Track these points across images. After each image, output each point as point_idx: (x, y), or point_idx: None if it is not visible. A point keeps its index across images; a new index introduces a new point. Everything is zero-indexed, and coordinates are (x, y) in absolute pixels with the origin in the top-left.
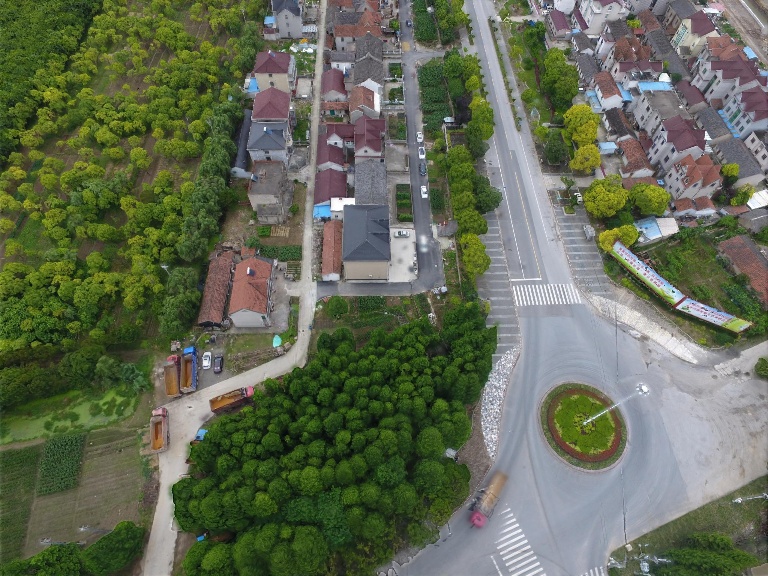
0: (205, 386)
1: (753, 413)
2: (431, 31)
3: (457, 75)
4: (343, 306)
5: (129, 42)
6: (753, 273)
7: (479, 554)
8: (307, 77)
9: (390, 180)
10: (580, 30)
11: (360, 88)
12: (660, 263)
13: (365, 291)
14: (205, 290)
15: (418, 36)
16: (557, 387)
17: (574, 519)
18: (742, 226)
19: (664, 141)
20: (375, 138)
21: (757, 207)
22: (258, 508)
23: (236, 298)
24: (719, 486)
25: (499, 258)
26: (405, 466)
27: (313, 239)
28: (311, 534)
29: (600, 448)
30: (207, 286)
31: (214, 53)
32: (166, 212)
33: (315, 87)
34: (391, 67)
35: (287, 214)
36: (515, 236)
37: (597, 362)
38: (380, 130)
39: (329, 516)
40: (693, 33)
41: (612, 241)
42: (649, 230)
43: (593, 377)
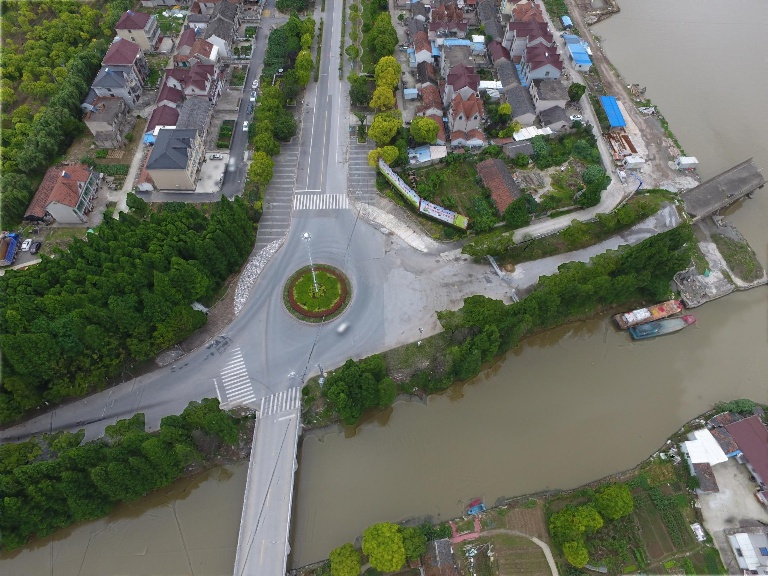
0: (21, 263)
1: (459, 286)
2: (291, 1)
3: (294, 34)
4: (138, 202)
5: (19, 6)
6: (495, 186)
7: (205, 377)
8: (171, 36)
9: (220, 117)
10: (420, 1)
11: (199, 41)
12: (424, 180)
13: (173, 199)
14: (36, 193)
15: (278, 5)
16: (305, 266)
17: (288, 356)
18: (505, 154)
19: (446, 84)
20: (200, 79)
21: (521, 139)
22: (11, 323)
23: (52, 195)
24: (412, 335)
25: (290, 175)
26: (137, 300)
27: (141, 160)
28: (43, 337)
29: (323, 307)
30: (38, 190)
31: (91, 15)
32: (17, 135)
33: (176, 45)
34: (246, 29)
35: (124, 141)
36: (310, 159)
37: (345, 250)
38: (207, 73)
39: (58, 325)
40: (509, 2)
41: (375, 158)
42: (422, 155)
43: (338, 260)
